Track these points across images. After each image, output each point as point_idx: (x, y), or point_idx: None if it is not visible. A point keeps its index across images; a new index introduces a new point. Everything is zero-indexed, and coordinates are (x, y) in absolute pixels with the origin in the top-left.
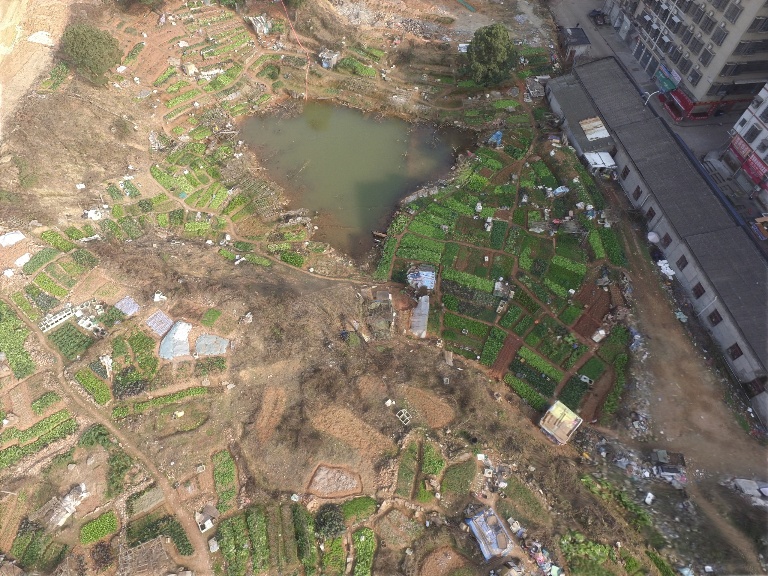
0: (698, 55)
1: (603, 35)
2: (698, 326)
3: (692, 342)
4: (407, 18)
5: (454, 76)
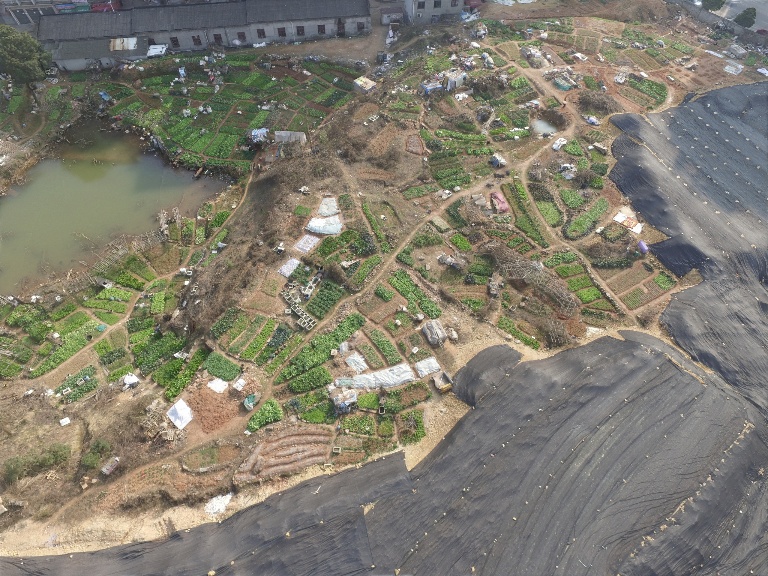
0: None
1: None
2: None
3: (314, 42)
4: None
5: None
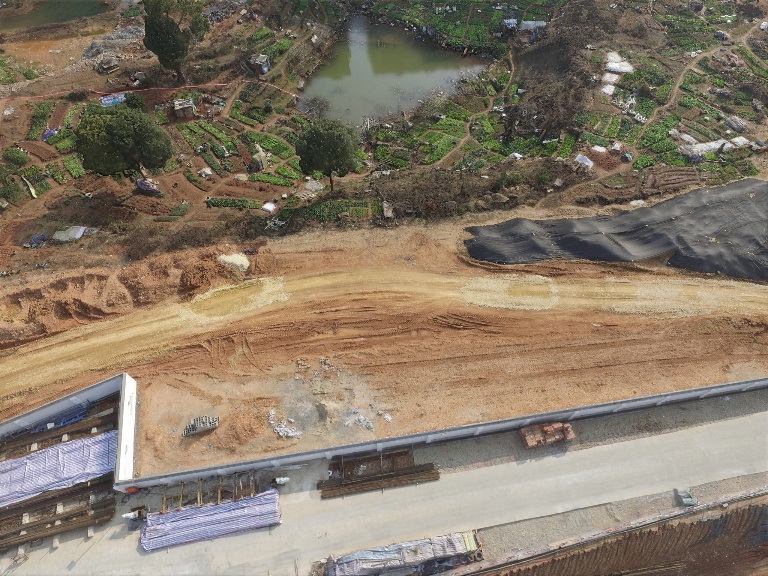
0: None
1: None
2: None
3: None
4: None
5: (296, 5)
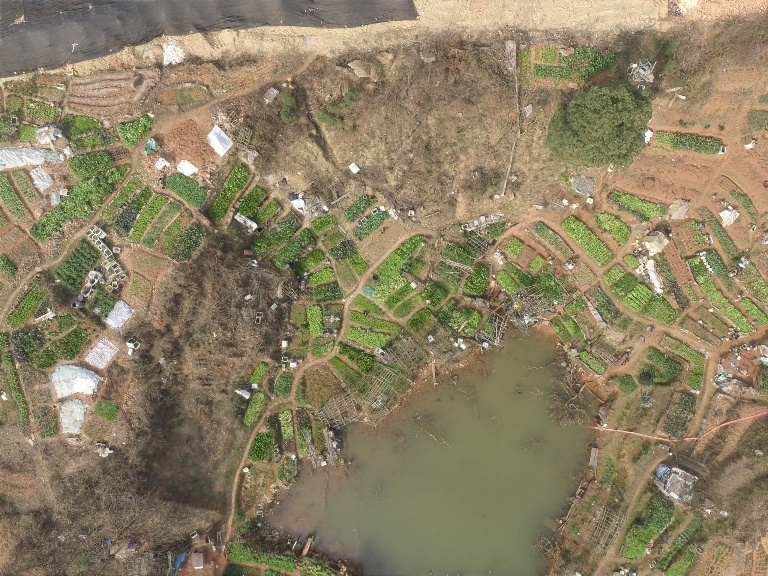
0: None
1: None
2: None
3: None
4: None
5: None
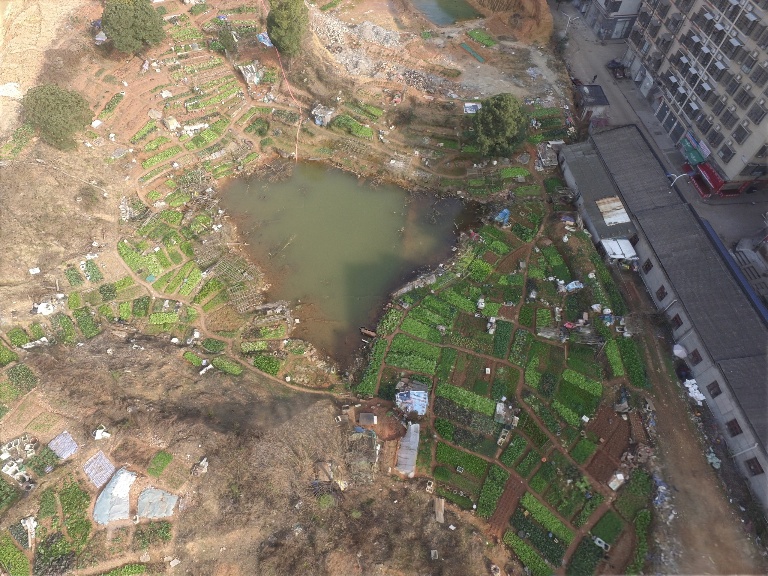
0: (731, 130)
1: (622, 90)
2: (733, 472)
3: (727, 497)
4: (410, 69)
5: (458, 140)
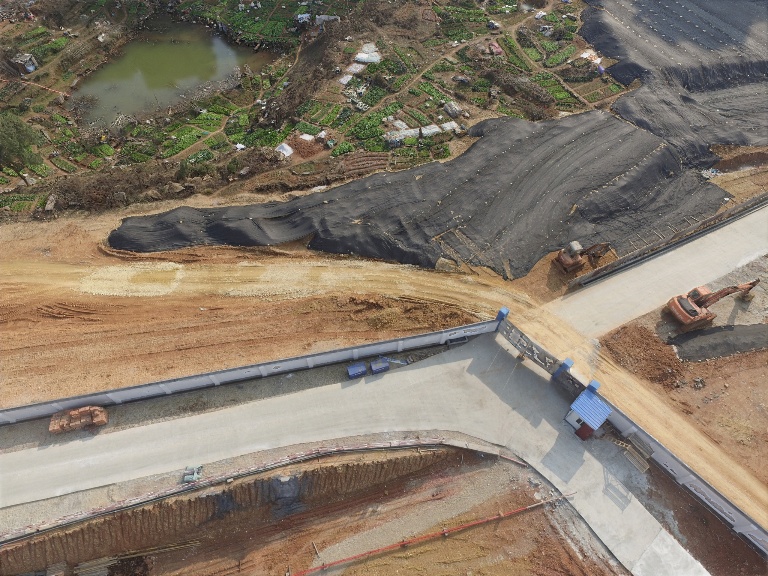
0: None
1: None
2: None
3: None
4: None
5: (90, 4)
